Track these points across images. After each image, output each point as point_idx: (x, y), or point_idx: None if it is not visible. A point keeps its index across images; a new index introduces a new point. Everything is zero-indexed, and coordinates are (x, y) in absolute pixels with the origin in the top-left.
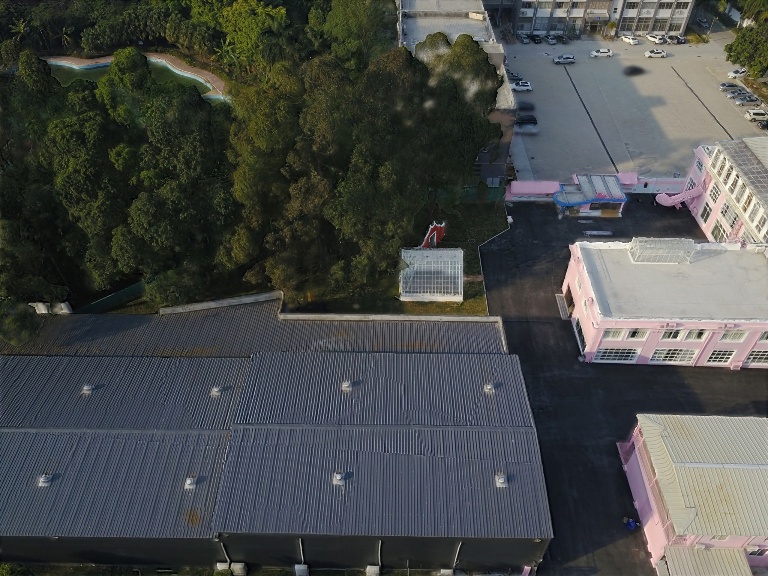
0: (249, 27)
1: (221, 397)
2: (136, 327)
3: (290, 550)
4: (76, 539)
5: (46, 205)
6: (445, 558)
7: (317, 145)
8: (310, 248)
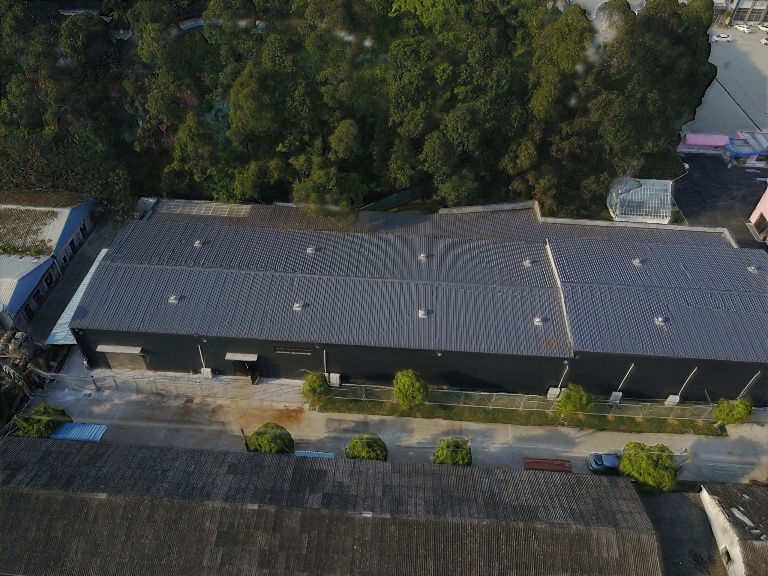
0: None
1: (533, 267)
2: (424, 222)
3: (617, 376)
4: (455, 357)
5: (374, 112)
6: (735, 390)
7: (616, 69)
8: (567, 164)
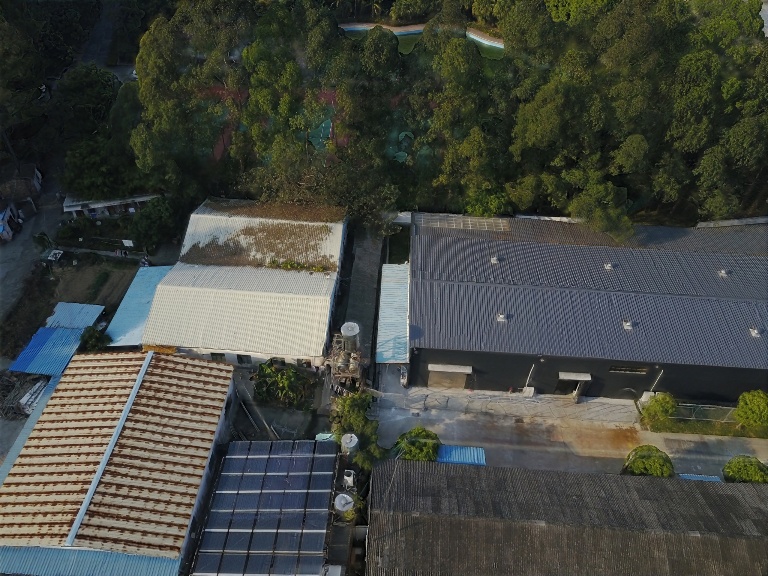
0: (582, 2)
1: None
2: (686, 236)
3: None
4: None
5: (654, 126)
6: None
7: None
8: None
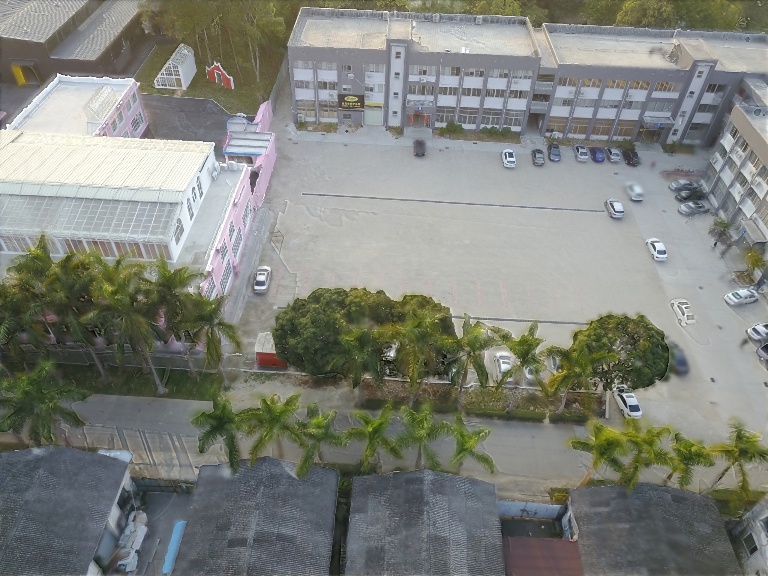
0: None
1: None
2: None
3: None
4: None
5: None
6: None
7: None
8: None
